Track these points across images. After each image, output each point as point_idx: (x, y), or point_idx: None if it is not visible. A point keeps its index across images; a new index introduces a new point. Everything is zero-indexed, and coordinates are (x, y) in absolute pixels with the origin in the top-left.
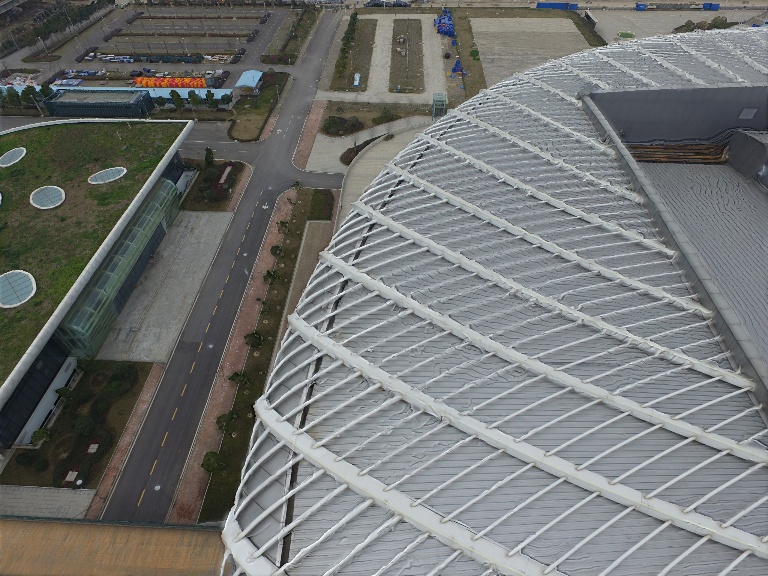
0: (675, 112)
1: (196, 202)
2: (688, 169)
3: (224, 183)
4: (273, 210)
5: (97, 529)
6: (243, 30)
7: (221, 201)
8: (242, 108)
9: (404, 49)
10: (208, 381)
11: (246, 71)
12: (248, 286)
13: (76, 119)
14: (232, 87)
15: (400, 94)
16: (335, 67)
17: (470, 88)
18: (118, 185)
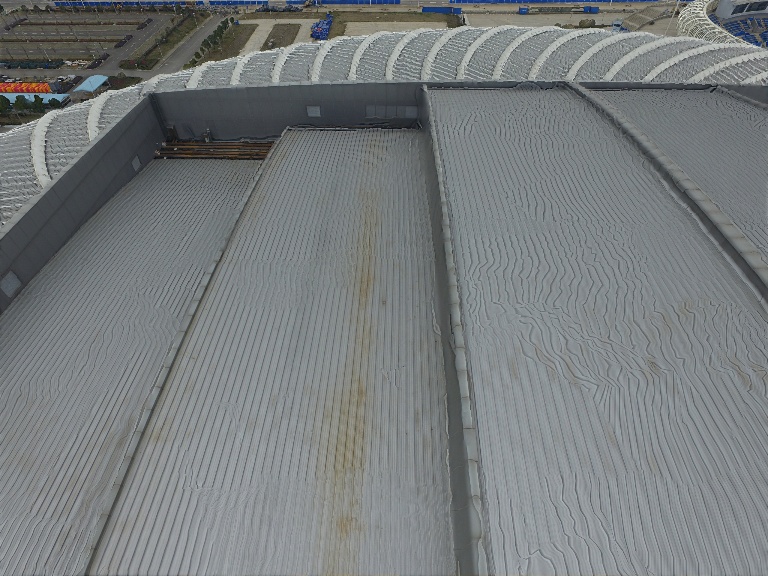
0: (244, 110)
1: None
2: (246, 165)
3: None
4: None
5: None
6: (118, 36)
7: None
8: None
9: None
10: None
11: (92, 76)
12: None
13: None
14: None
15: None
16: None
17: None
18: None
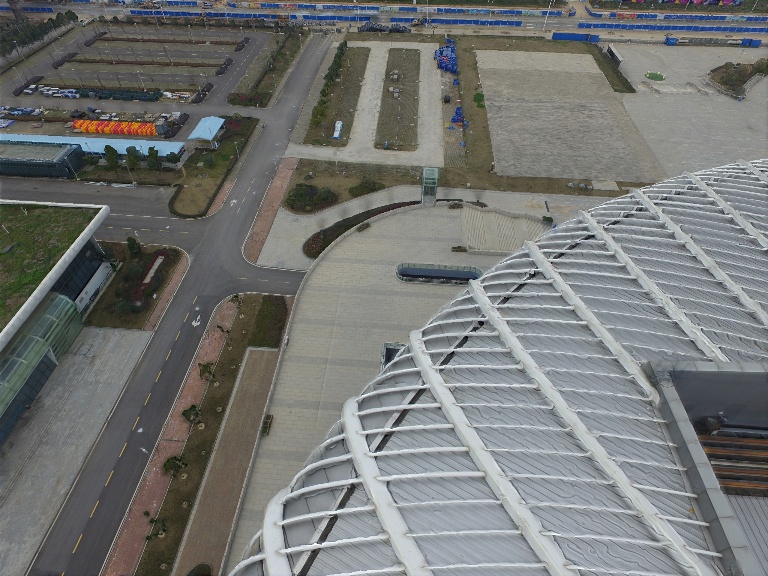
0: None
1: (107, 313)
2: None
3: (149, 284)
4: (205, 329)
5: None
6: (215, 58)
7: (140, 313)
8: (194, 167)
9: (397, 89)
10: None
11: (205, 117)
12: (149, 464)
13: None
14: (188, 136)
15: (387, 151)
16: None
17: (471, 146)
18: None
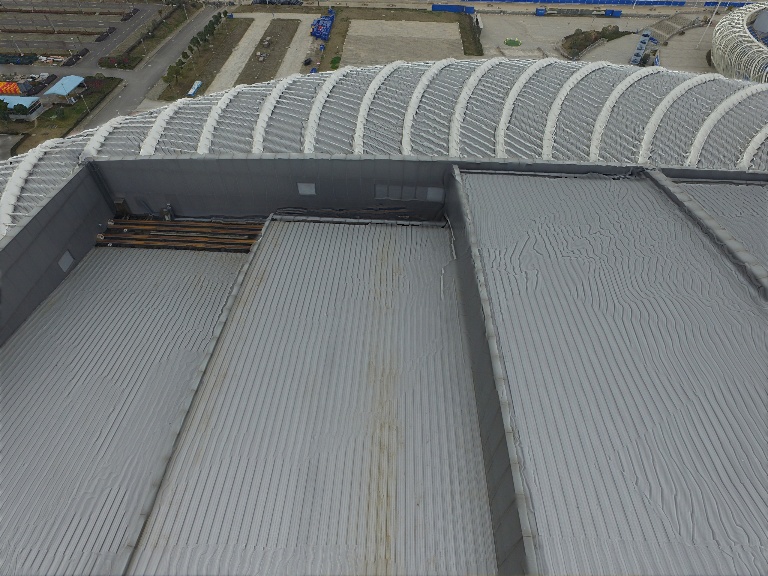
0: (215, 185)
1: None
2: (216, 261)
3: None
4: None
5: None
6: (100, 27)
7: None
8: (47, 119)
9: (264, 53)
10: None
11: None
12: None
13: None
14: None
15: None
16: (167, 74)
17: None
18: None
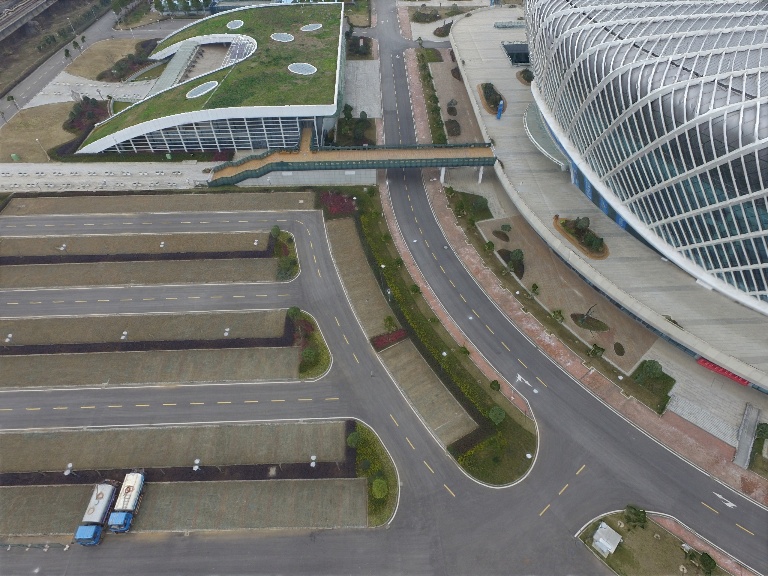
0: None
1: (351, 56)
2: None
3: None
4: (404, 58)
5: (402, 151)
6: None
7: (368, 55)
8: (348, 11)
9: None
10: (411, 123)
11: None
12: (410, 89)
13: (264, 4)
14: None
15: (456, 1)
16: None
17: None
18: (322, 31)
